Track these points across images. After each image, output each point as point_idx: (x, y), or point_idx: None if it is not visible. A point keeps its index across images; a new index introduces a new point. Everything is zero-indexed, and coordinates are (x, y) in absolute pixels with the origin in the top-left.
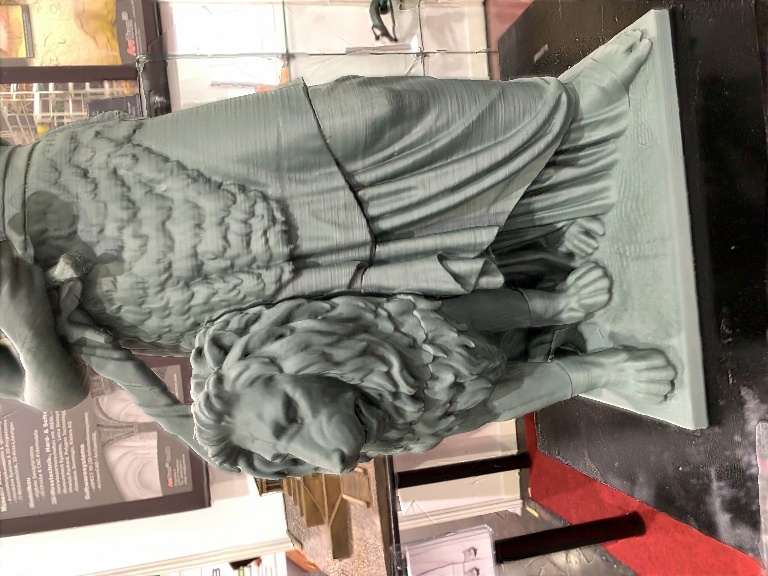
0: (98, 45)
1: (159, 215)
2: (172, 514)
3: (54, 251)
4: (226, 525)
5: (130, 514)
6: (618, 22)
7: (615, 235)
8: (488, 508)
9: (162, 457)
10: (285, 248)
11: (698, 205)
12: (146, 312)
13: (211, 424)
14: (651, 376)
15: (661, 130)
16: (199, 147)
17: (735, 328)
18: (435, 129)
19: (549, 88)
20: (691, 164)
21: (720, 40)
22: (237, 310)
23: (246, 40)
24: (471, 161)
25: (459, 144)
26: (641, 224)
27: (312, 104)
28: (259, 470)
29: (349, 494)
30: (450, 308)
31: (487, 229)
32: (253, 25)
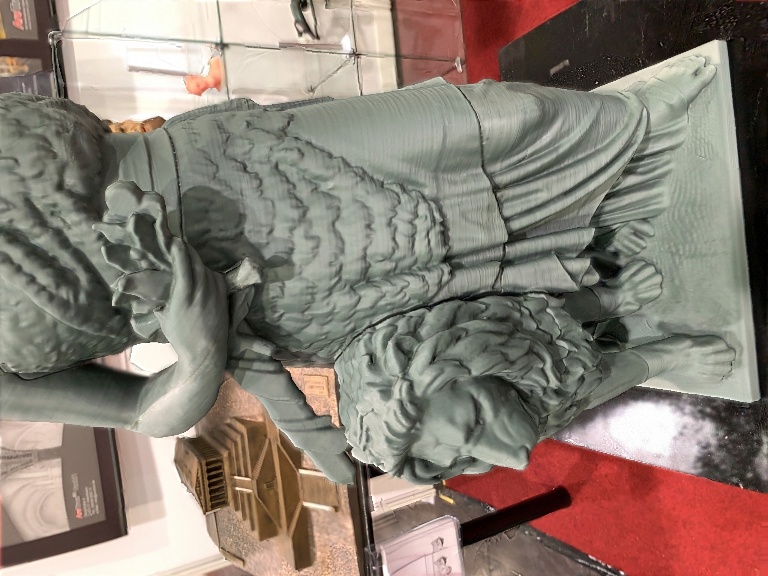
0: None
1: (330, 215)
2: (82, 549)
3: (217, 254)
4: (141, 553)
5: (30, 555)
6: (663, 47)
7: (666, 236)
8: (405, 500)
9: (68, 486)
10: (443, 249)
11: (753, 210)
12: (307, 319)
13: (403, 433)
14: (717, 359)
15: (723, 145)
16: (365, 143)
17: None
18: (559, 135)
19: (631, 102)
20: (748, 175)
21: None
22: (399, 313)
23: (176, 25)
24: (583, 167)
25: (573, 150)
26: (698, 226)
27: (472, 105)
28: (419, 476)
29: (311, 501)
30: None
31: (587, 230)
32: (184, 9)
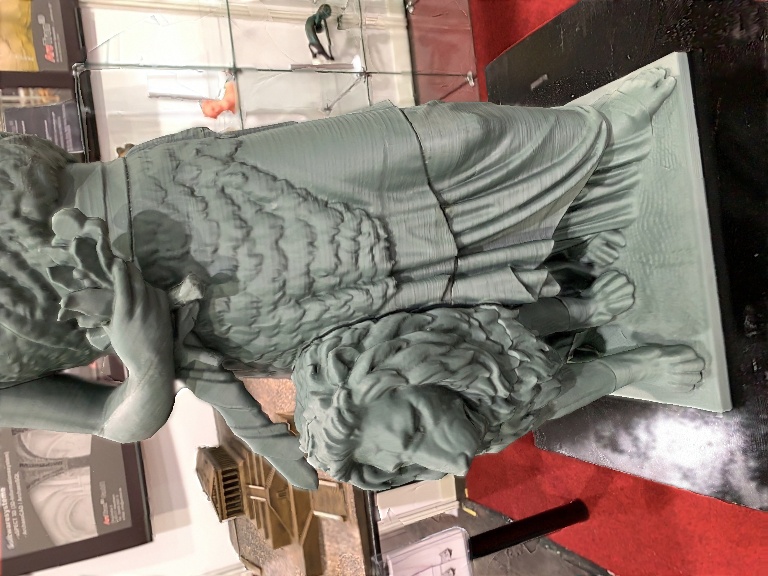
0: (11, 49)
1: (273, 234)
2: (110, 554)
3: (165, 272)
4: (166, 559)
5: (61, 559)
6: (630, 60)
7: (637, 246)
8: (428, 512)
9: (96, 493)
10: (388, 264)
11: (718, 219)
12: (255, 332)
13: (341, 439)
14: (685, 368)
15: (686, 155)
16: (307, 166)
17: (760, 323)
18: (509, 151)
19: (590, 116)
20: (711, 184)
21: (743, 81)
22: (345, 326)
23: (191, 52)
24: (536, 181)
25: (526, 165)
26: (665, 236)
27: (413, 127)
28: (368, 482)
29: (321, 510)
30: (519, 316)
31: (545, 243)
32: (198, 37)
